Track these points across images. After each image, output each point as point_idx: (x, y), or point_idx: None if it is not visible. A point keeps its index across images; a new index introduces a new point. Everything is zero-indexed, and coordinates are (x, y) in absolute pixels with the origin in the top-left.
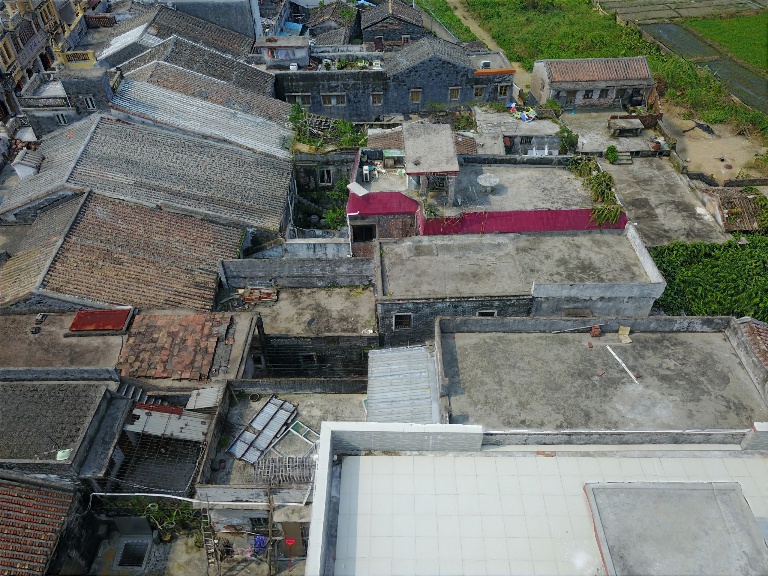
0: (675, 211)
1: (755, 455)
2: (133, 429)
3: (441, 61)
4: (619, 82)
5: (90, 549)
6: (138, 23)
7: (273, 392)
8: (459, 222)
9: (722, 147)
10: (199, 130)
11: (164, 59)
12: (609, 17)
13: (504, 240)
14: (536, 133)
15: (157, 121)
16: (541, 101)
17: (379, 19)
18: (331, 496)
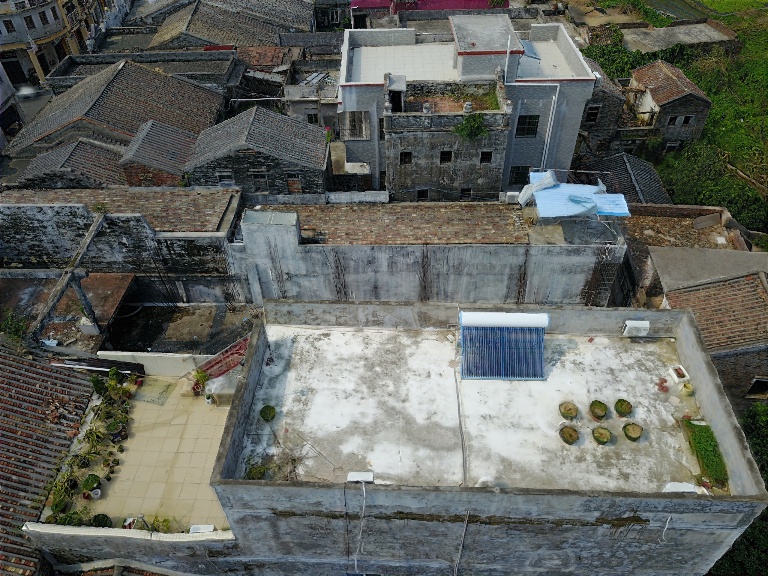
0: None
1: (534, 42)
2: (248, 75)
3: None
4: None
5: None
6: None
7: (316, 70)
8: (414, 5)
9: (610, 20)
10: None
11: None
12: None
13: None
14: None
15: None
16: None
17: None
18: (350, 55)
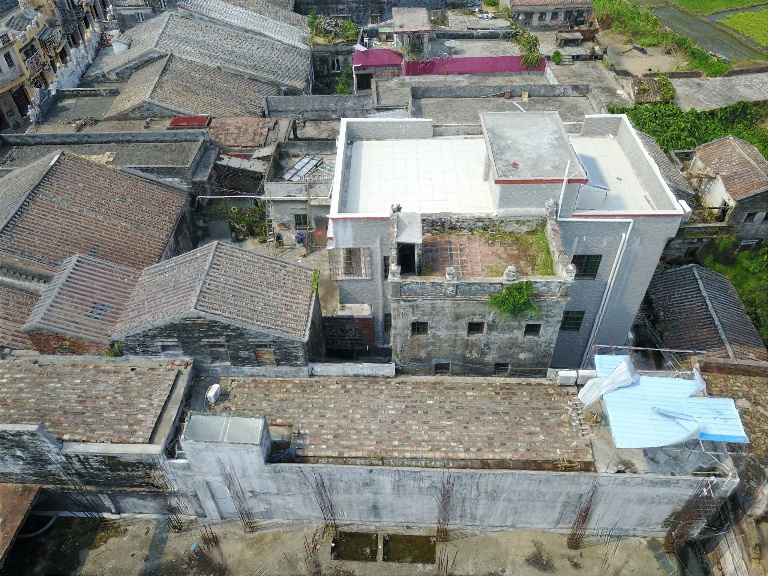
0: (601, 92)
1: (587, 137)
2: (221, 163)
3: None
4: (566, 6)
5: (194, 240)
6: None
7: (307, 153)
8: (430, 65)
9: (652, 62)
10: (242, 26)
11: None
12: None
13: (461, 79)
14: (492, 26)
15: (212, 18)
16: None
17: None
18: (347, 154)
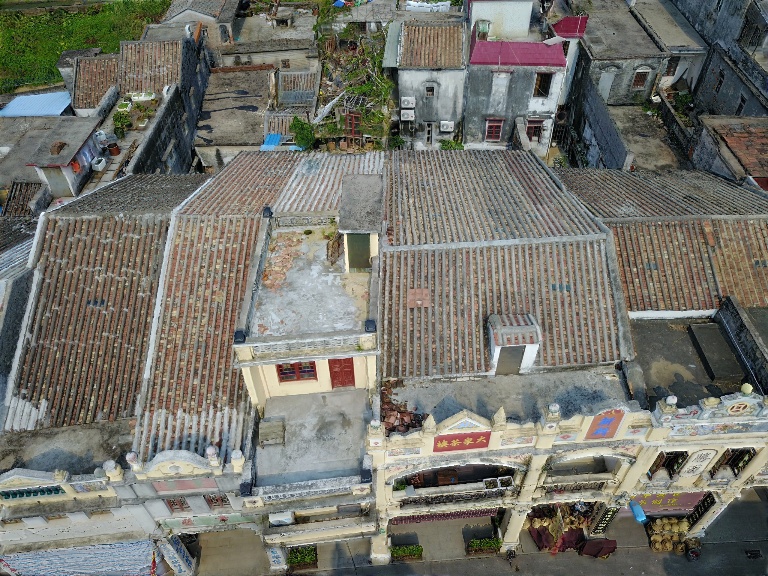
0: None
1: None
2: None
3: (185, 43)
4: None
5: None
6: None
7: None
8: None
9: None
10: None
11: (163, 209)
12: None
13: None
14: None
15: None
16: (211, 48)
17: None
18: None
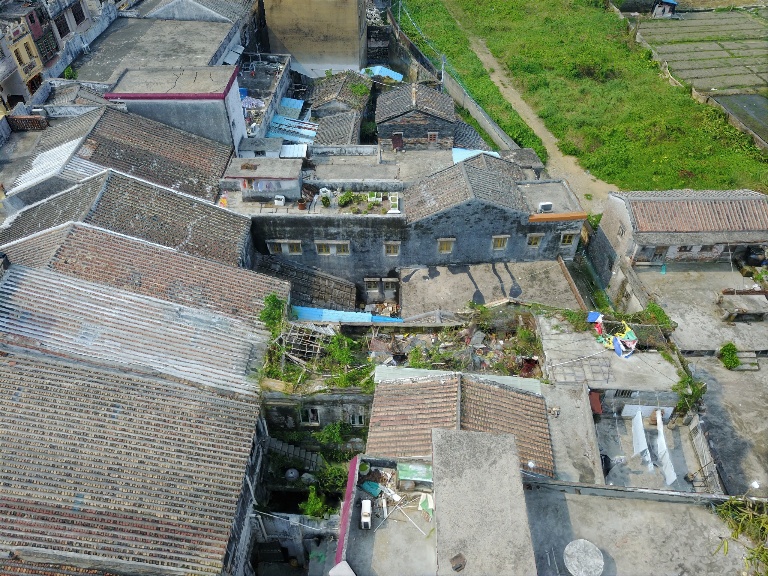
0: None
1: None
2: None
3: (484, 205)
4: (733, 235)
5: None
6: (73, 133)
7: None
8: None
9: None
10: (115, 359)
11: (84, 217)
12: (683, 89)
13: None
14: (641, 386)
15: (47, 351)
16: (618, 249)
17: (399, 112)
18: None
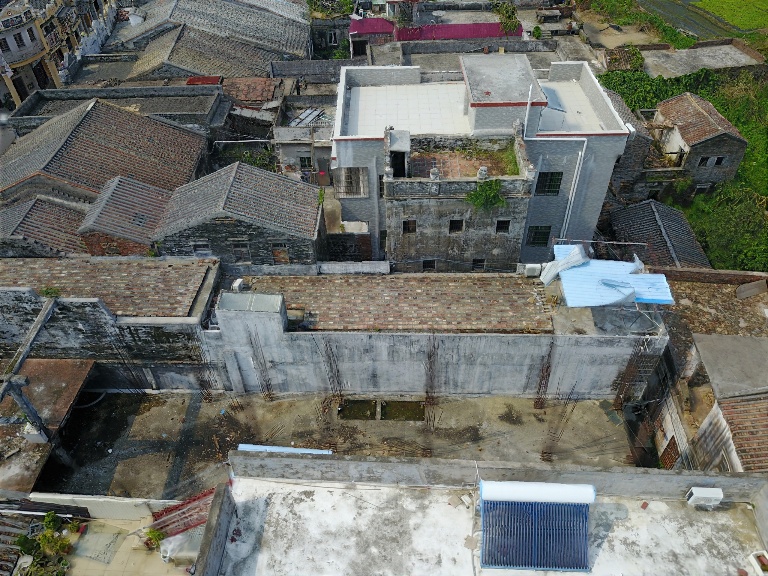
0: None
1: (554, 82)
2: (234, 113)
3: None
4: None
5: None
6: None
7: (310, 106)
8: (419, 31)
9: (626, 39)
10: (247, 2)
11: None
12: None
13: None
14: (476, 0)
15: None
16: None
17: None
18: (346, 97)
